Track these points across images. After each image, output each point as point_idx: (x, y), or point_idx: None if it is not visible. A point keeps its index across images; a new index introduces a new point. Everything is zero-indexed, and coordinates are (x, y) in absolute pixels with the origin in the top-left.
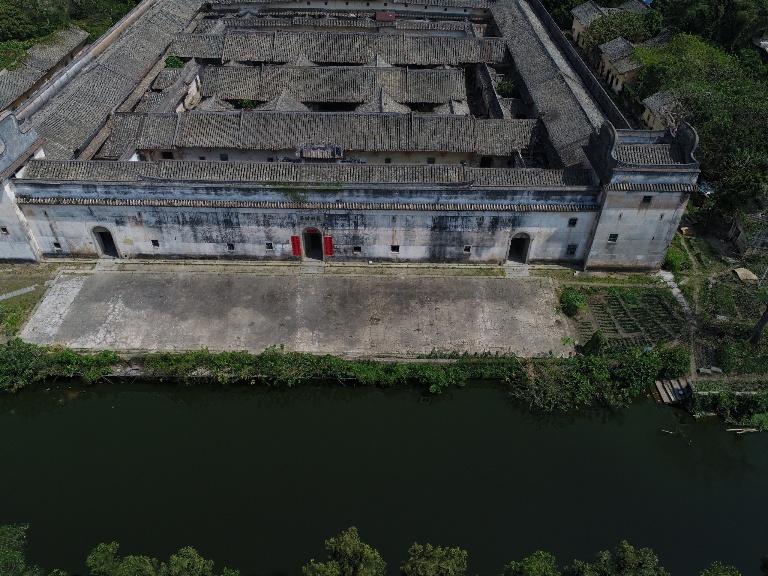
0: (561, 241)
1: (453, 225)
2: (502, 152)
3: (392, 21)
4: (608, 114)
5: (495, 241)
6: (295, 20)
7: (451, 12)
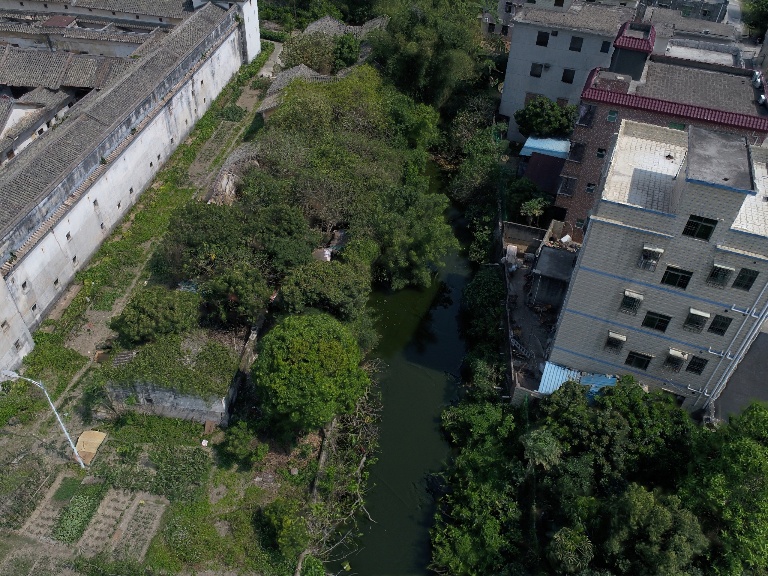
0: None
1: None
2: None
3: (61, 28)
4: None
5: None
6: None
7: (145, 20)
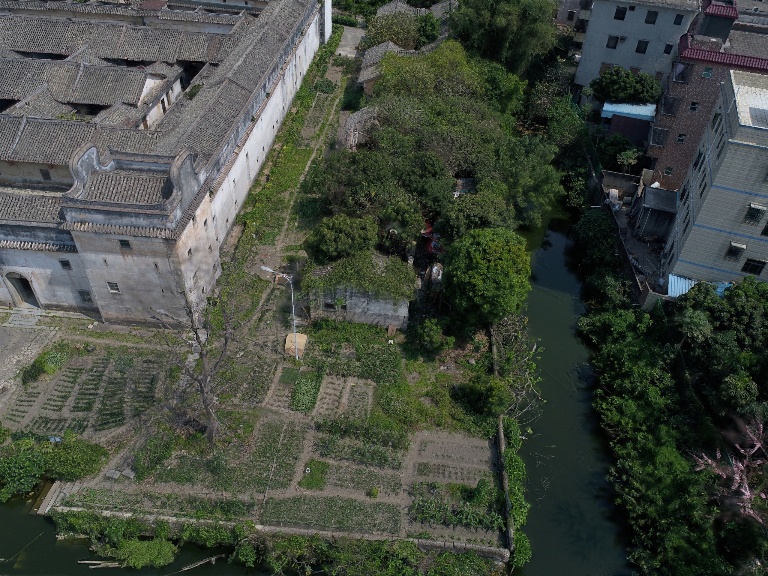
0: (67, 285)
1: None
2: None
3: (156, 10)
4: None
5: None
6: (50, 4)
7: (231, 4)
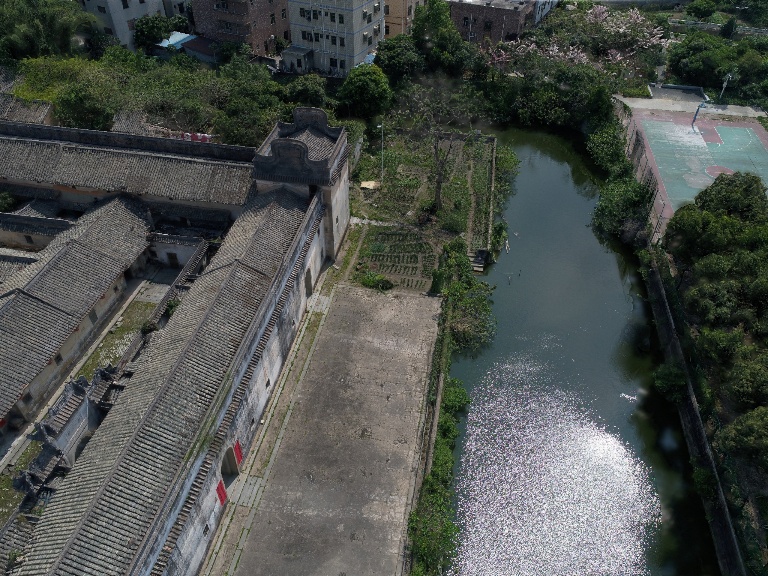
0: (318, 254)
1: (284, 313)
2: (141, 247)
3: None
4: (167, 150)
5: (300, 296)
6: None
7: None
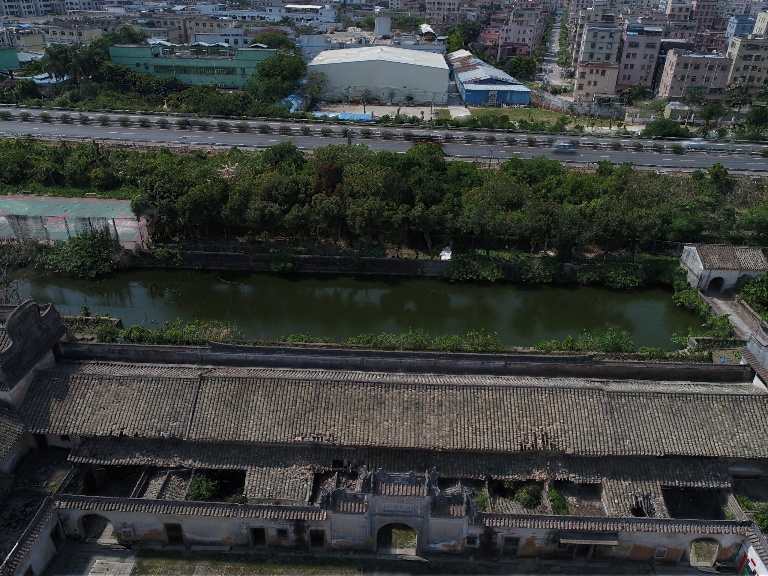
0: None
1: None
2: None
3: None
4: None
5: None
6: None
7: None
